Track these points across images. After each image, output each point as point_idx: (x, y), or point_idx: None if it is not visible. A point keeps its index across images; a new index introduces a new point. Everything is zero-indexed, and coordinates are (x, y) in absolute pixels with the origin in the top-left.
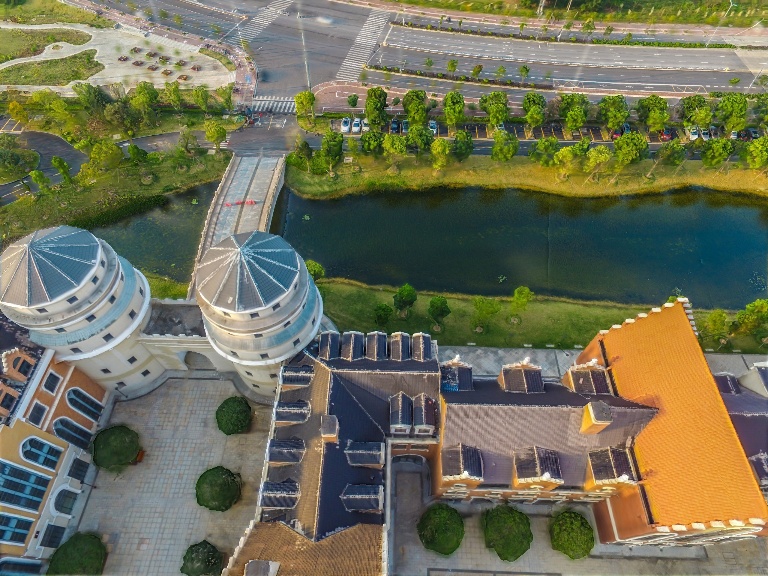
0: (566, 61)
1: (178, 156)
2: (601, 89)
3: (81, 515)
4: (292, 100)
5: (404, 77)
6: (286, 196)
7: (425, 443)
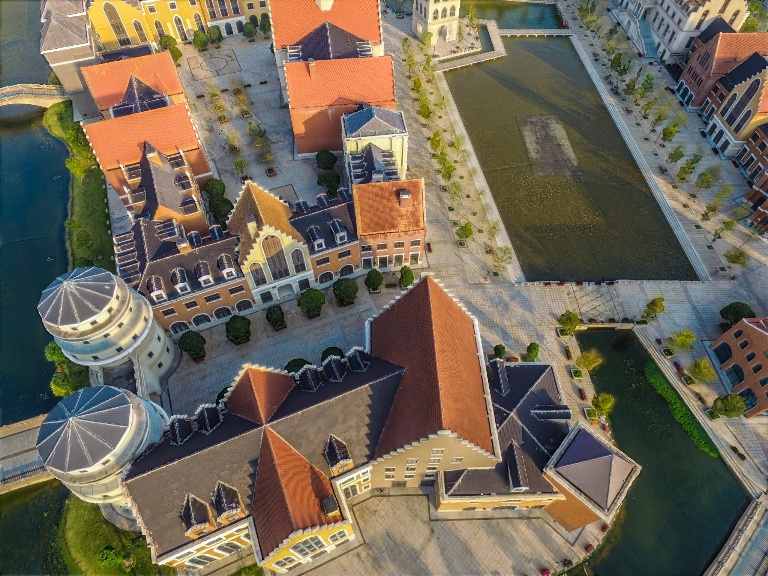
0: None
1: None
2: None
3: None
4: None
5: None
6: None
7: None
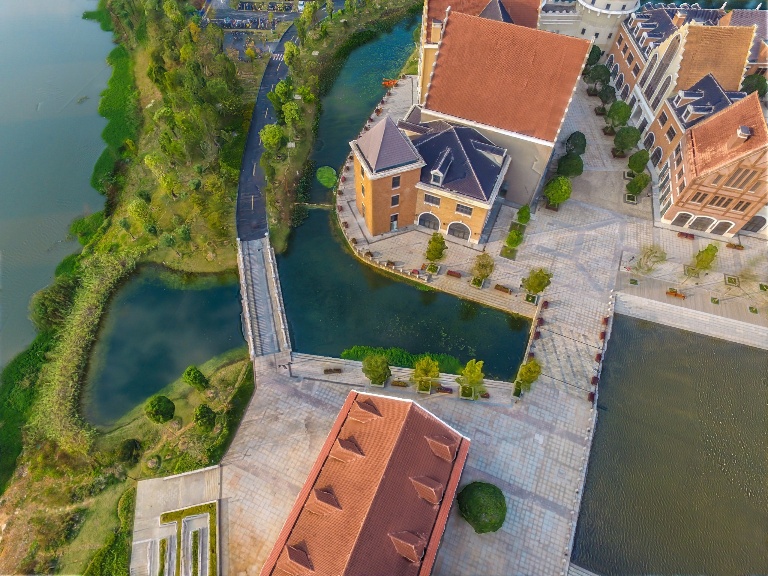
0: None
1: None
2: None
3: None
4: None
5: None
6: None
7: None
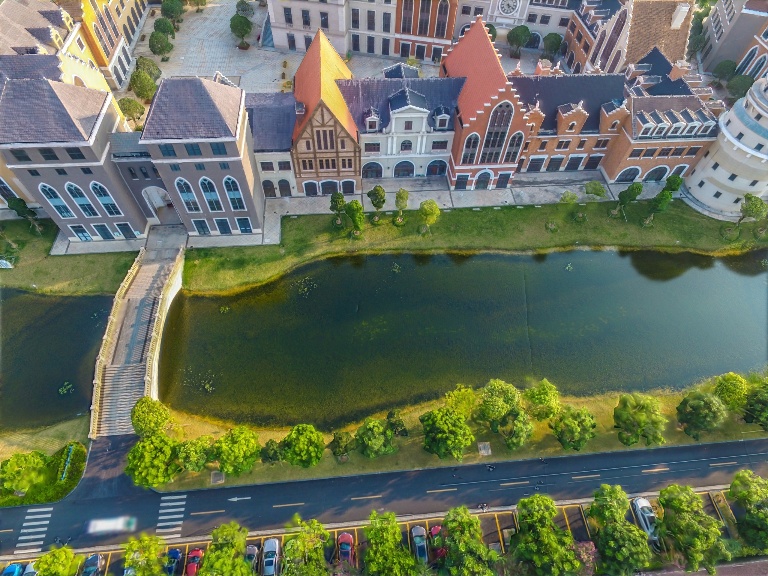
0: None
1: None
2: None
3: None
4: None
5: None
6: None
7: None
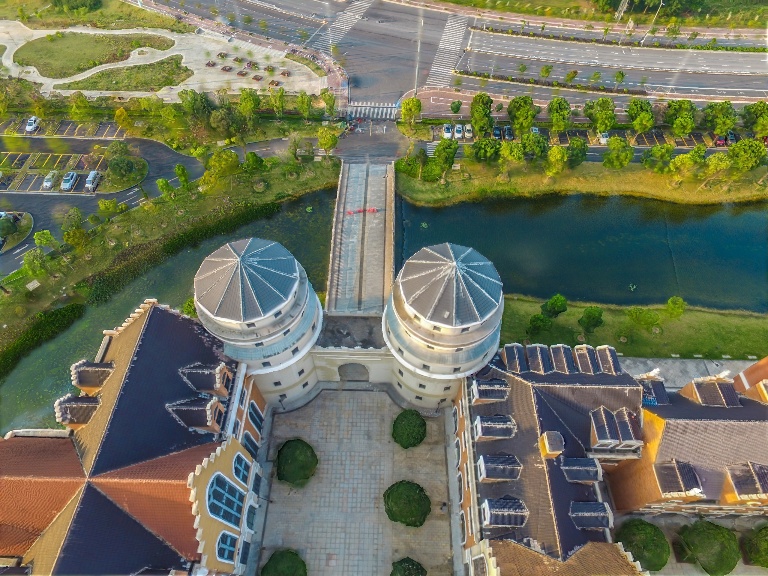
0: (653, 66)
1: (293, 163)
2: (694, 95)
3: (263, 530)
4: (388, 106)
5: (495, 83)
6: (399, 203)
7: (627, 458)
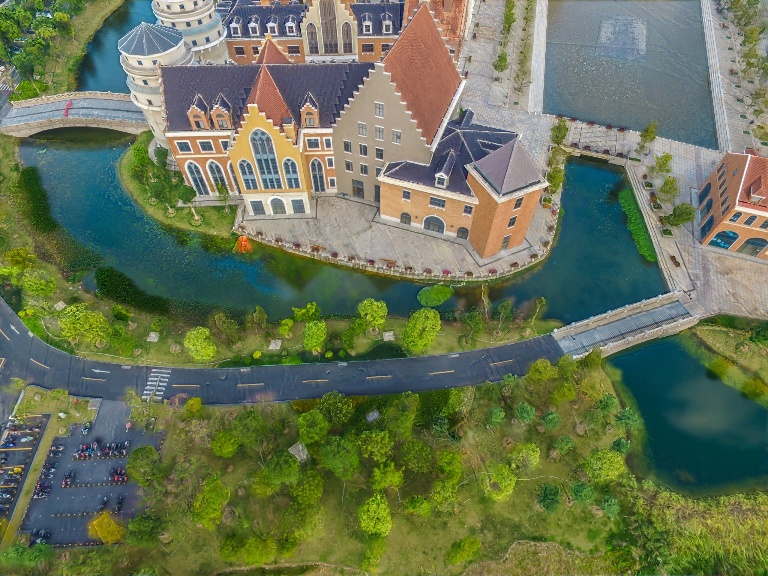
0: None
1: None
2: None
3: None
4: None
5: None
6: None
7: None
